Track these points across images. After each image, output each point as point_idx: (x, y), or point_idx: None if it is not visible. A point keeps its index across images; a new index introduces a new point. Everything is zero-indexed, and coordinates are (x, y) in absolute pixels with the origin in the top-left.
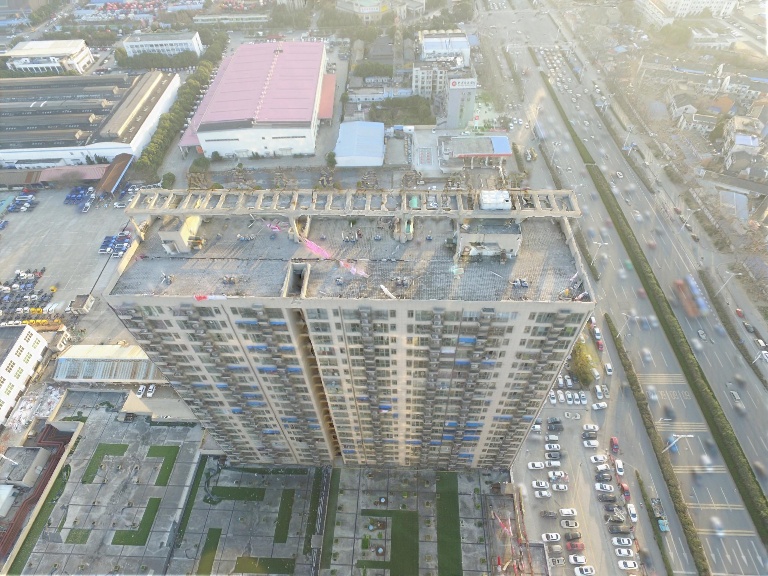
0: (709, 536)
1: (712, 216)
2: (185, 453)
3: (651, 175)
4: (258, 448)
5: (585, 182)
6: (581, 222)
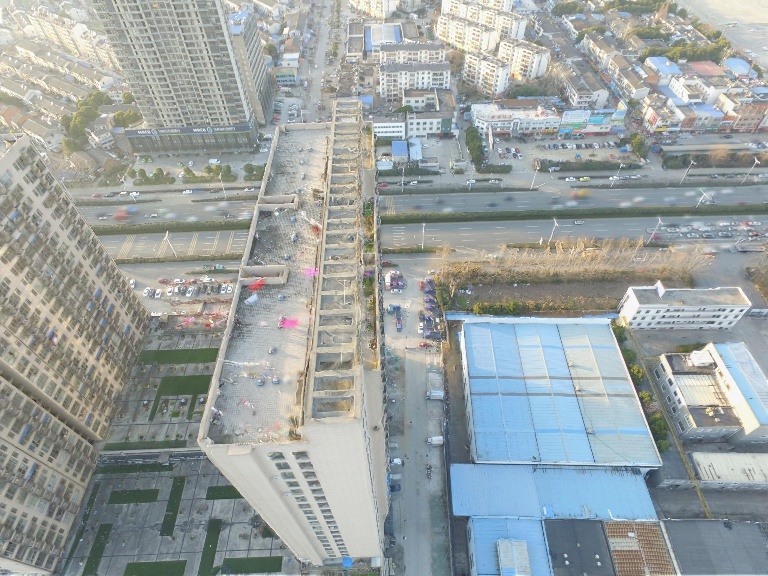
0: (230, 250)
1: None
2: None
3: None
4: (47, 512)
5: None
6: None
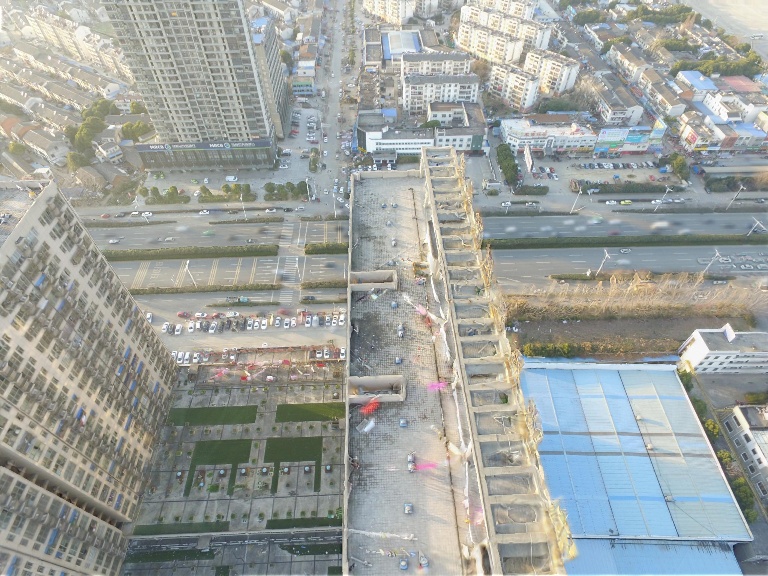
0: (254, 279)
1: None
2: None
3: None
4: None
5: None
6: None
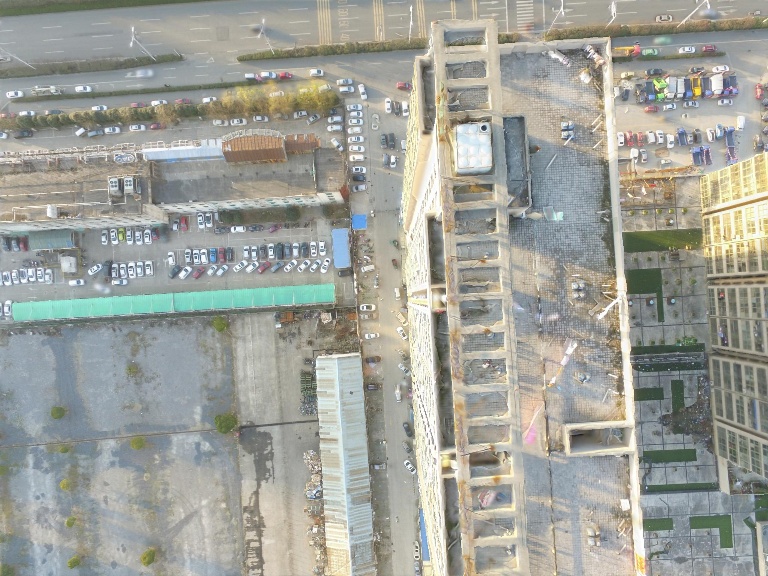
0: None
1: None
2: None
3: None
4: None
5: None
6: (69, 57)
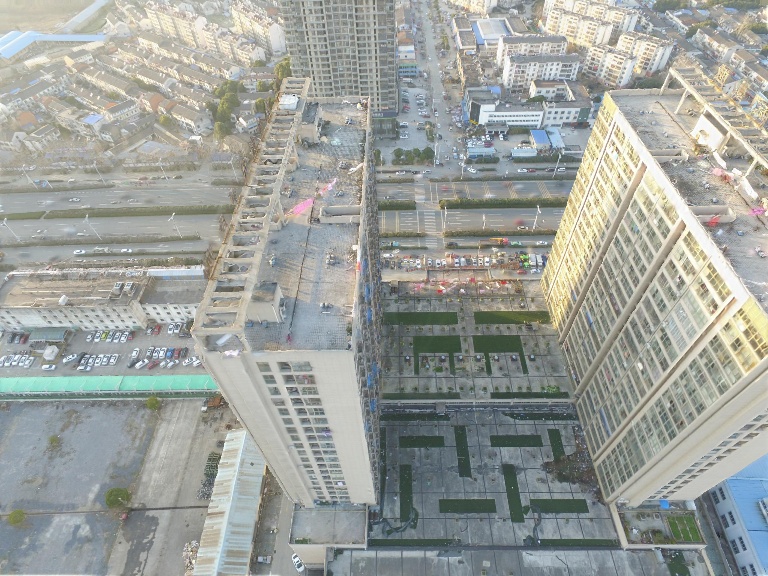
0: (399, 228)
1: (161, 162)
2: (365, 572)
3: (89, 182)
4: (376, 447)
5: (69, 224)
6: (127, 234)
